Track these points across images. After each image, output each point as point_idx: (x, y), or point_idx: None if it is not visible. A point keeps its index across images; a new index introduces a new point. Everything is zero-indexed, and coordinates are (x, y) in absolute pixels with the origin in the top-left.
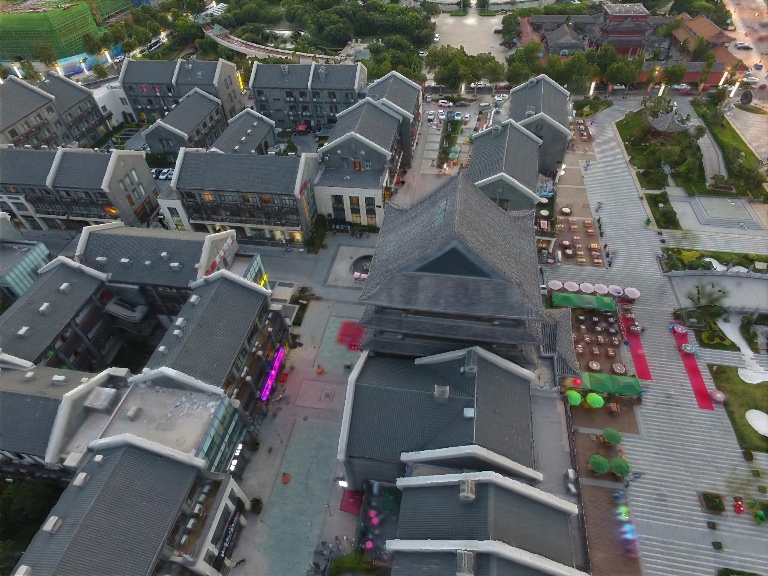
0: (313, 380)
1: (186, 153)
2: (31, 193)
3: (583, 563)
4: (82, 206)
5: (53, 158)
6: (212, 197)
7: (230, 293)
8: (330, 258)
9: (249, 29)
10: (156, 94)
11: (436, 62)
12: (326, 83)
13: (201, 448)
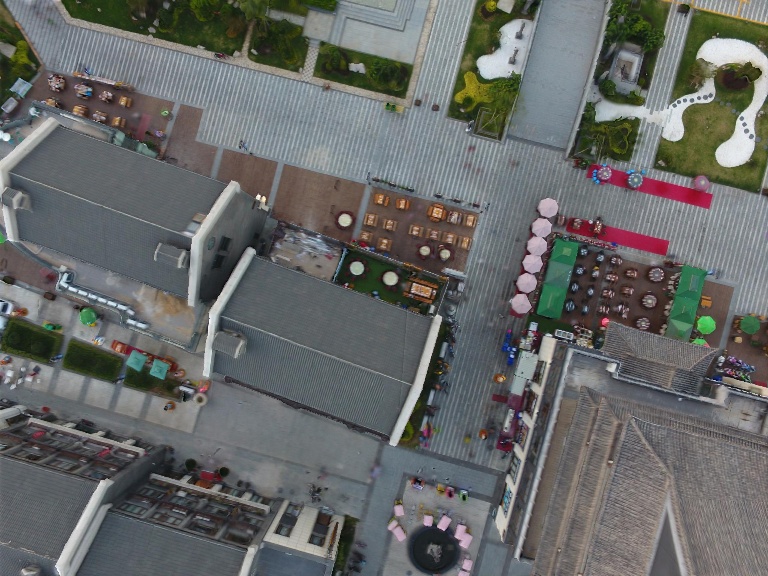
0: None
1: None
2: None
3: None
4: None
5: None
6: None
7: None
8: None
9: None
10: None
11: None
12: None
13: None
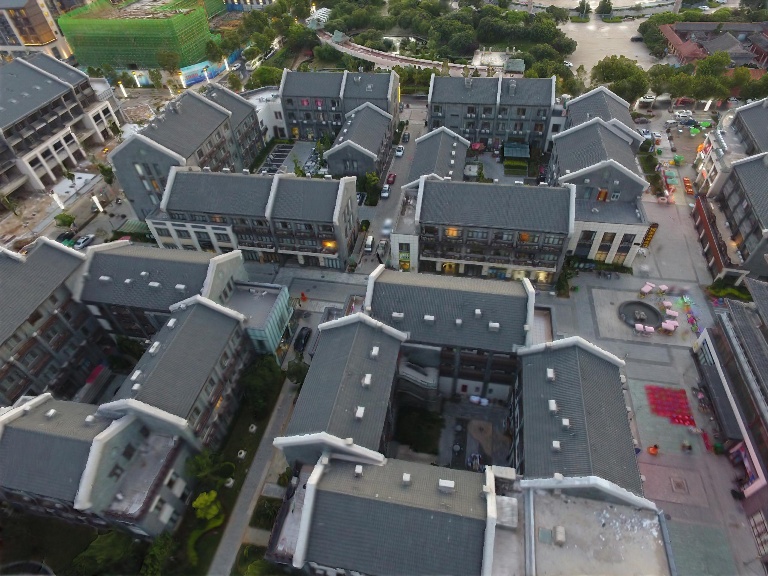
0: (650, 463)
1: (426, 182)
2: (239, 223)
3: None
4: (297, 239)
5: (268, 185)
6: (457, 233)
7: (591, 366)
8: (587, 303)
9: (369, 36)
10: (317, 108)
11: (609, 74)
12: (517, 98)
13: None
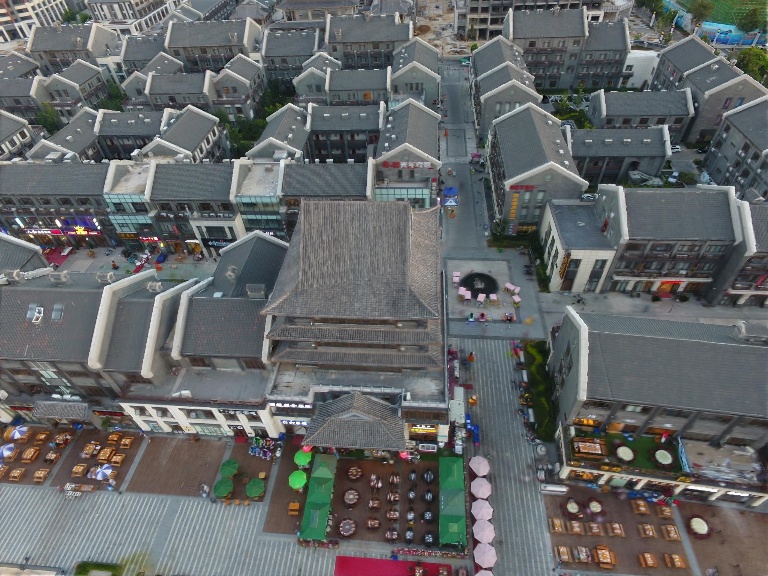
0: None
1: (528, 108)
2: None
3: (127, 397)
4: None
5: None
6: None
7: (357, 173)
8: (485, 257)
9: None
10: (671, 78)
11: None
12: None
13: (241, 196)
